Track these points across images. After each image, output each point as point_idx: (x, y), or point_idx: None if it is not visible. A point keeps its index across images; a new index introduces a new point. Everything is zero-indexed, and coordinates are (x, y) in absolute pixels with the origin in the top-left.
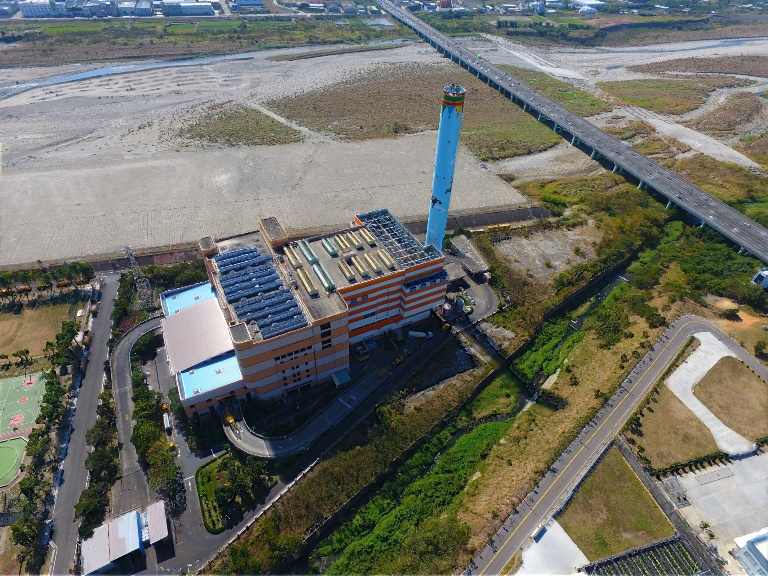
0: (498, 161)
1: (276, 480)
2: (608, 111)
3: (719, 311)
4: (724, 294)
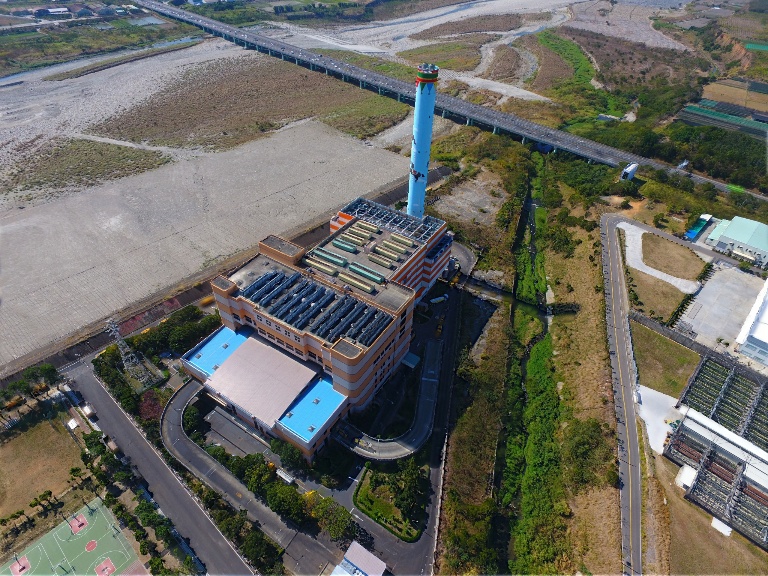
0: (374, 137)
1: (428, 469)
2: None
3: (617, 205)
4: (610, 193)
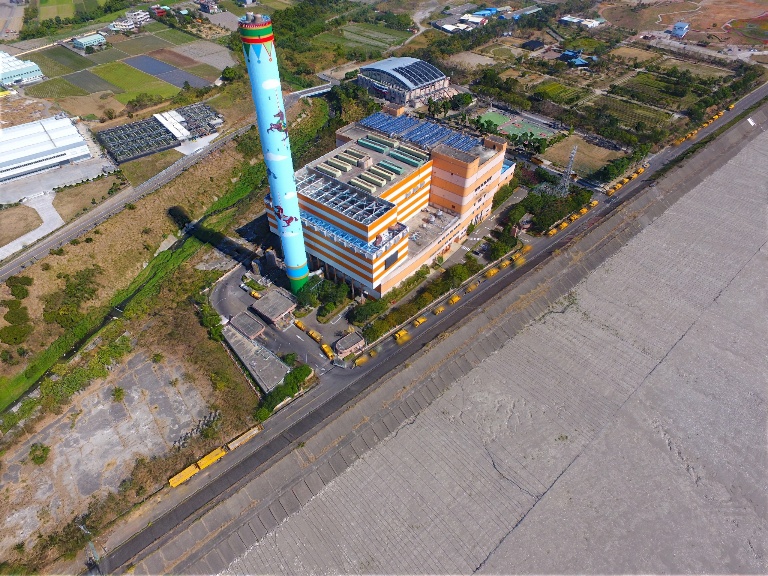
0: None
1: None
2: None
3: None
4: None
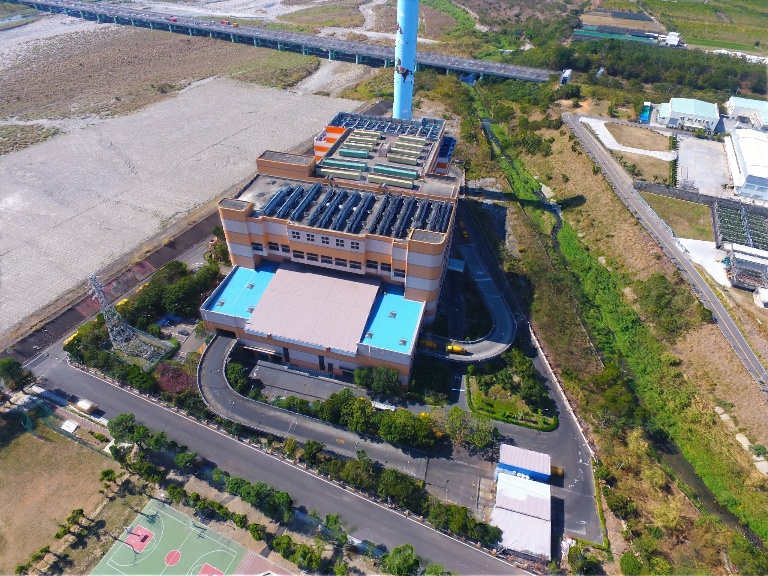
0: (295, 86)
1: (528, 359)
2: (318, 32)
3: None
4: (556, 98)
